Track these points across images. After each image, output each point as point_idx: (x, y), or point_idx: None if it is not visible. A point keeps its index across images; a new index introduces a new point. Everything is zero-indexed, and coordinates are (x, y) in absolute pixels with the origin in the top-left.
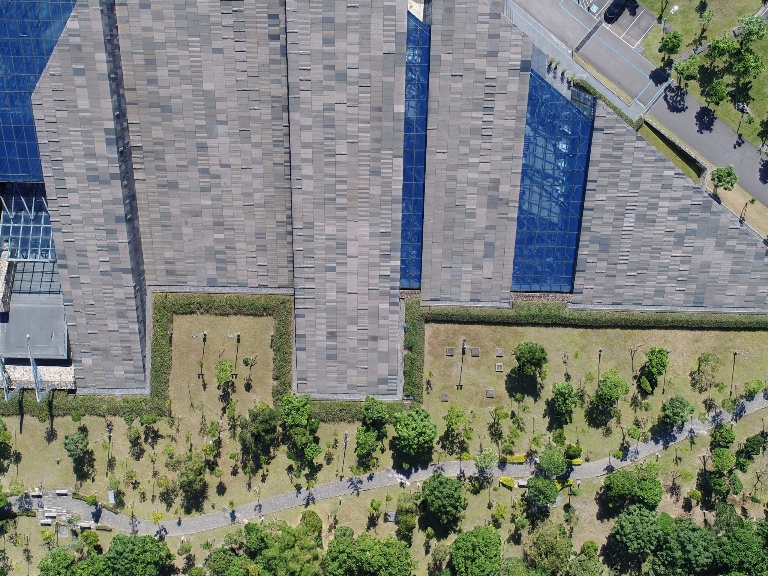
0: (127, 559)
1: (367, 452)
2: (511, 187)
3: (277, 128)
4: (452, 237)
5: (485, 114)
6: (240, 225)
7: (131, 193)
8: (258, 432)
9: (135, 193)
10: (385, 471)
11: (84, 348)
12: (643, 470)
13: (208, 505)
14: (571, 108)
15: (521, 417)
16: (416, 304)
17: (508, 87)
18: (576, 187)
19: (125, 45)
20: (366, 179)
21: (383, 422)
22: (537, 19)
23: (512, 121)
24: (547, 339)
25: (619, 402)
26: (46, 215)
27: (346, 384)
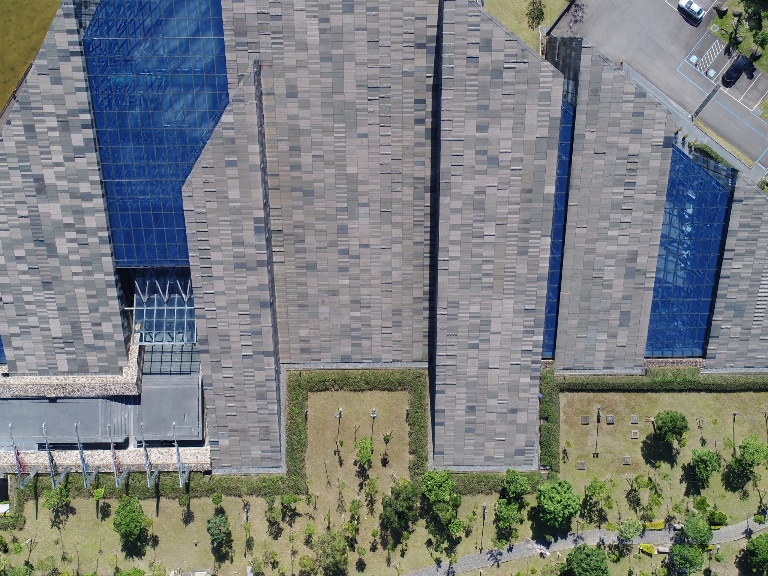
0: None
1: (509, 525)
2: (649, 258)
3: (418, 208)
4: (588, 308)
5: (626, 189)
6: (377, 303)
7: (272, 276)
8: None
9: (273, 275)
10: (525, 542)
11: (222, 430)
12: None
13: None
14: (710, 180)
15: (658, 483)
16: (551, 374)
17: (650, 163)
18: (712, 256)
19: (270, 133)
20: (513, 258)
21: (525, 494)
22: (656, 85)
23: (653, 195)
24: (681, 404)
25: None
26: (179, 297)
27: (483, 456)
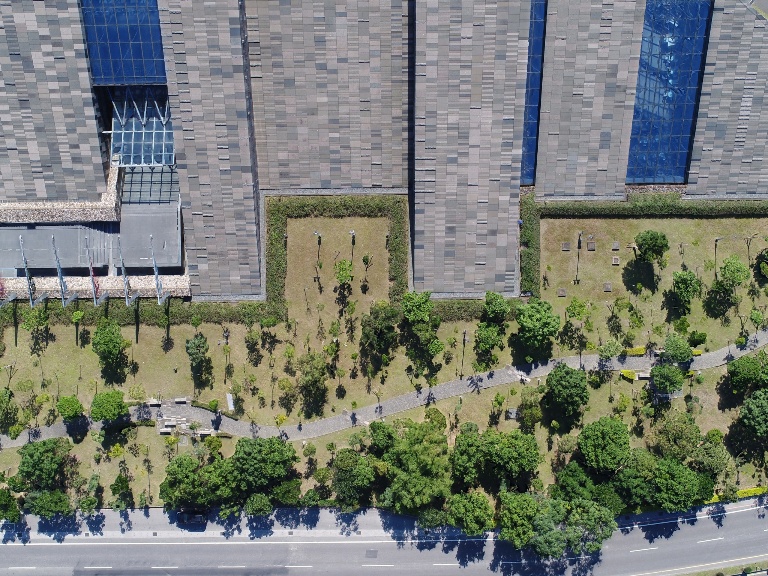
0: (256, 459)
1: (489, 347)
2: (629, 73)
3: (396, 18)
4: (568, 128)
5: None
6: (356, 122)
7: (249, 90)
8: (380, 330)
9: (251, 92)
10: (505, 368)
11: (200, 253)
12: (767, 355)
13: (328, 409)
14: None
15: (639, 310)
16: (531, 199)
17: None
18: (693, 72)
19: None
20: (491, 63)
21: (504, 316)
22: None
23: (632, 3)
24: (663, 231)
25: (736, 291)
26: (157, 121)
27: (463, 282)
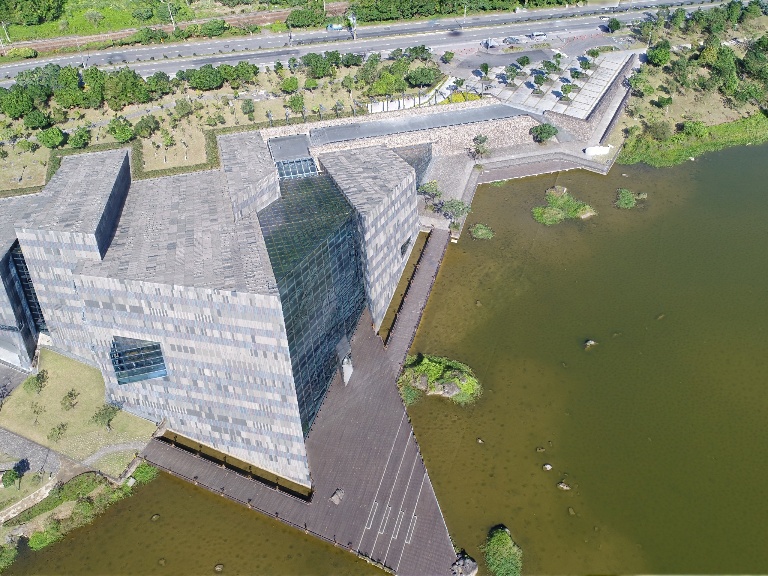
0: None
1: None
2: None
3: None
4: None
5: None
6: None
7: None
8: None
9: None
10: None
11: None
12: None
13: None
14: None
15: None
16: None
17: None
18: None
19: None
20: None
21: None
22: None
23: None
24: None
25: None
26: None
27: None
